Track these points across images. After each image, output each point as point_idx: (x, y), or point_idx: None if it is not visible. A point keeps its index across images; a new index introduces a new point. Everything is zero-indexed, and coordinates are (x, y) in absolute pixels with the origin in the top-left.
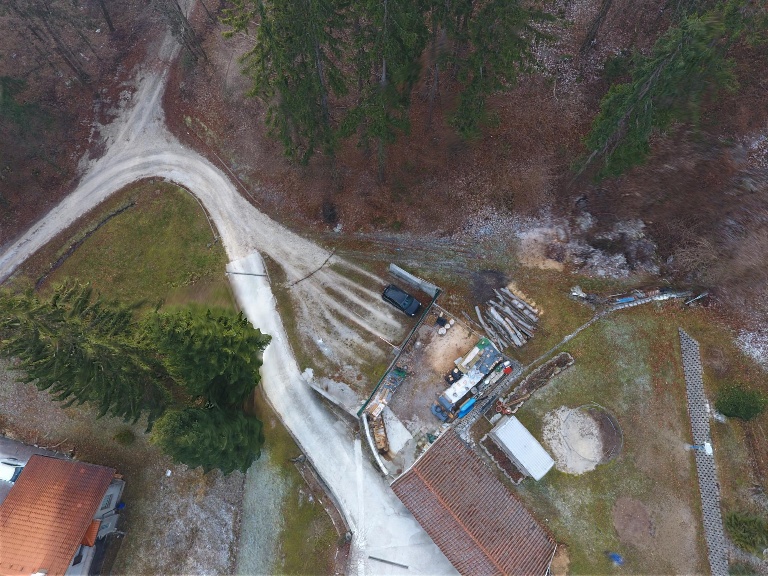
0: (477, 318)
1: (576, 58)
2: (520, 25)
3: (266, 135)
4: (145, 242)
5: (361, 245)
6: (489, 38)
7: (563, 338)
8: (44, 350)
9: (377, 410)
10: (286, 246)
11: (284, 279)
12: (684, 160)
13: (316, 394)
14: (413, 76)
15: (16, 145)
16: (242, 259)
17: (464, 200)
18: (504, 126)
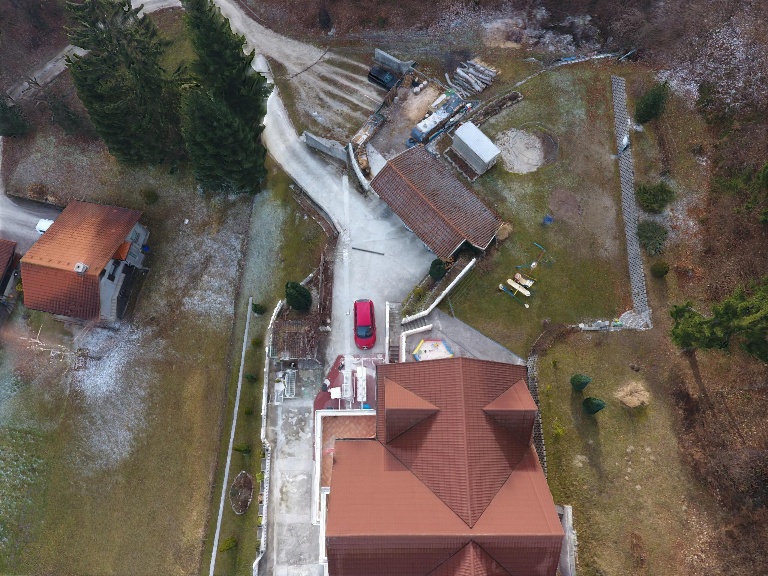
0: (446, 82)
1: None
2: None
3: None
4: (166, 52)
5: (351, 43)
6: None
7: (515, 84)
8: (96, 36)
9: (361, 139)
10: (287, 50)
11: (285, 73)
12: None
13: (311, 149)
14: None
15: None
16: None
17: None
18: None
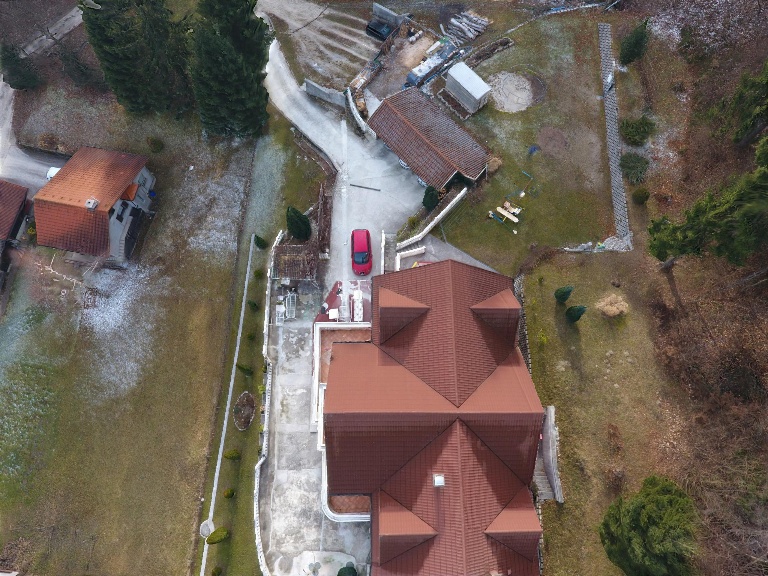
0: (441, 32)
1: None
2: None
3: None
4: None
5: None
6: None
7: (506, 31)
8: None
9: (359, 83)
10: (288, 7)
11: (287, 29)
12: None
13: (311, 98)
14: None
15: None
16: None
17: None
18: None
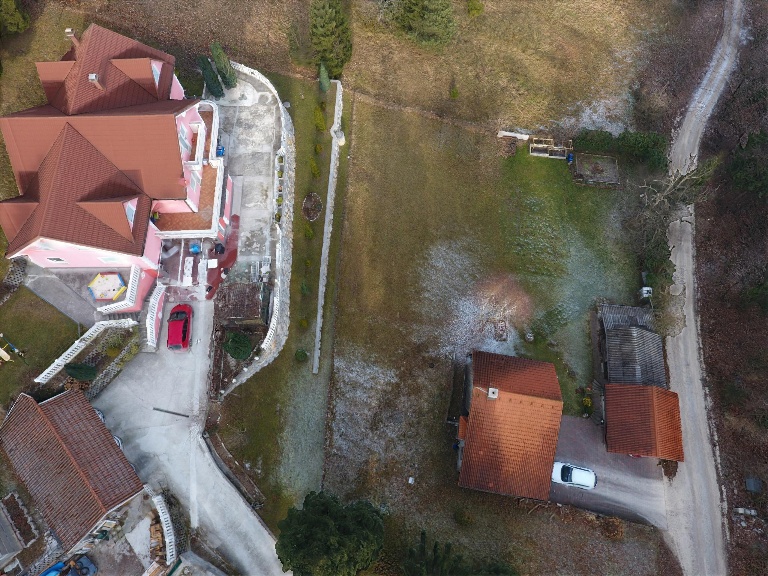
0: None
1: None
2: None
3: None
4: None
5: None
6: None
7: None
8: None
9: (151, 570)
10: None
11: None
12: None
13: None
14: None
15: None
16: None
17: None
18: None
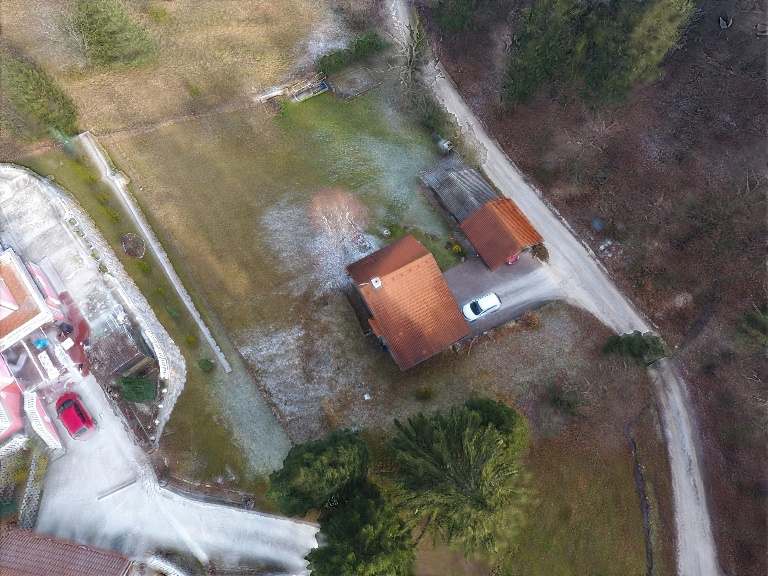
0: None
1: None
2: None
3: None
4: (584, 572)
5: None
6: None
7: None
8: None
9: None
10: None
11: None
12: None
13: (279, 570)
14: None
15: None
16: None
17: None
18: None
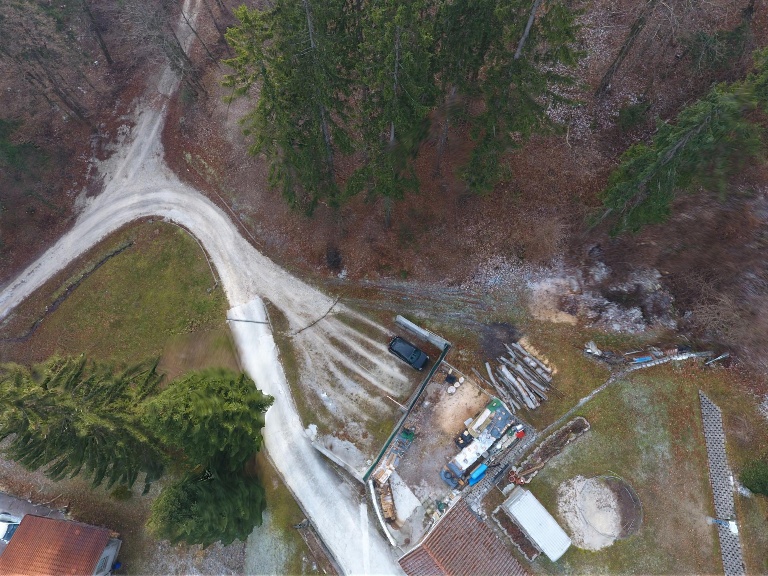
0: (488, 375)
1: (590, 104)
2: (538, 91)
3: (268, 174)
4: (143, 286)
5: (366, 293)
6: (504, 101)
7: (578, 401)
8: (35, 430)
9: (384, 477)
10: (289, 292)
11: (287, 327)
12: (702, 209)
13: (320, 453)
14: (423, 132)
15: (11, 183)
16: (243, 305)
17: (473, 248)
18: (515, 173)
